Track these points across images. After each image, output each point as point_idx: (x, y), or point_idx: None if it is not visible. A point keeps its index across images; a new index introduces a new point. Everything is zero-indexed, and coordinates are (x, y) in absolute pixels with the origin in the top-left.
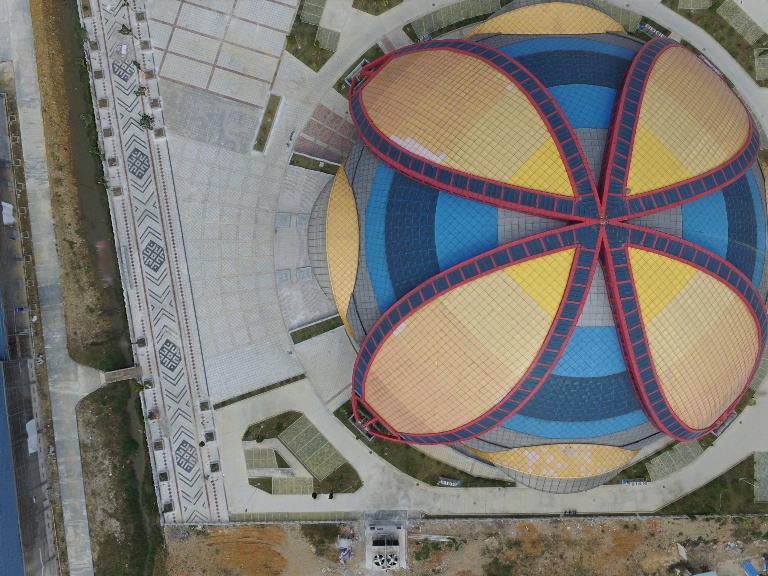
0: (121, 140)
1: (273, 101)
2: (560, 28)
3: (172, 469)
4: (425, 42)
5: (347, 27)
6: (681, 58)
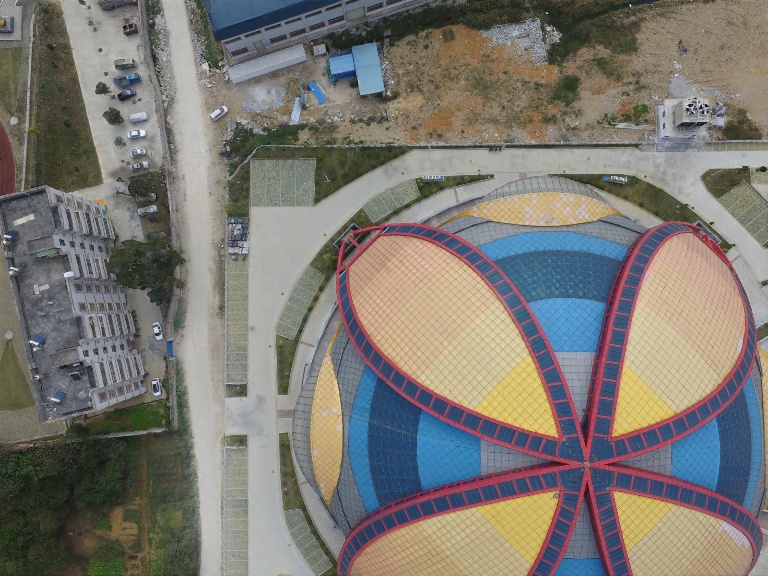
0: None
1: None
2: None
3: None
4: None
5: None
6: None
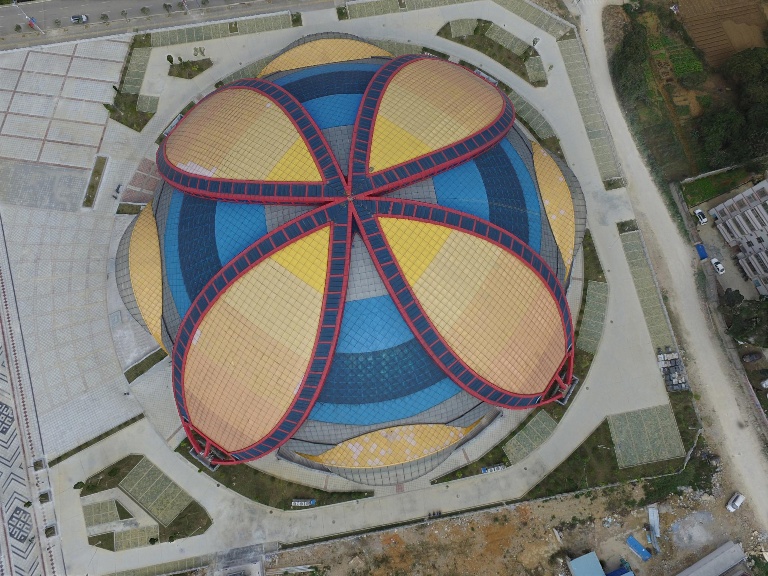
0: None
1: (100, 162)
2: (327, 59)
3: (4, 542)
4: (218, 88)
5: (165, 92)
6: (431, 66)
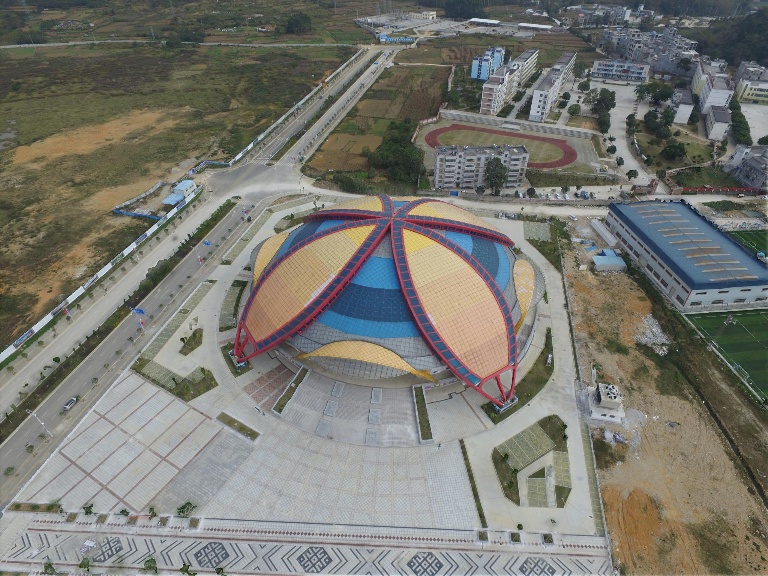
0: (177, 570)
1: (222, 418)
2: (278, 244)
3: None
4: (247, 301)
5: (197, 362)
6: None
